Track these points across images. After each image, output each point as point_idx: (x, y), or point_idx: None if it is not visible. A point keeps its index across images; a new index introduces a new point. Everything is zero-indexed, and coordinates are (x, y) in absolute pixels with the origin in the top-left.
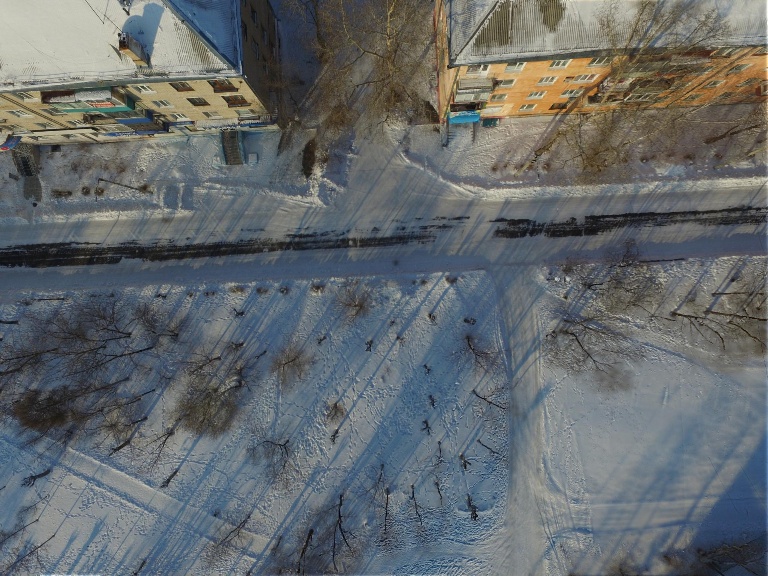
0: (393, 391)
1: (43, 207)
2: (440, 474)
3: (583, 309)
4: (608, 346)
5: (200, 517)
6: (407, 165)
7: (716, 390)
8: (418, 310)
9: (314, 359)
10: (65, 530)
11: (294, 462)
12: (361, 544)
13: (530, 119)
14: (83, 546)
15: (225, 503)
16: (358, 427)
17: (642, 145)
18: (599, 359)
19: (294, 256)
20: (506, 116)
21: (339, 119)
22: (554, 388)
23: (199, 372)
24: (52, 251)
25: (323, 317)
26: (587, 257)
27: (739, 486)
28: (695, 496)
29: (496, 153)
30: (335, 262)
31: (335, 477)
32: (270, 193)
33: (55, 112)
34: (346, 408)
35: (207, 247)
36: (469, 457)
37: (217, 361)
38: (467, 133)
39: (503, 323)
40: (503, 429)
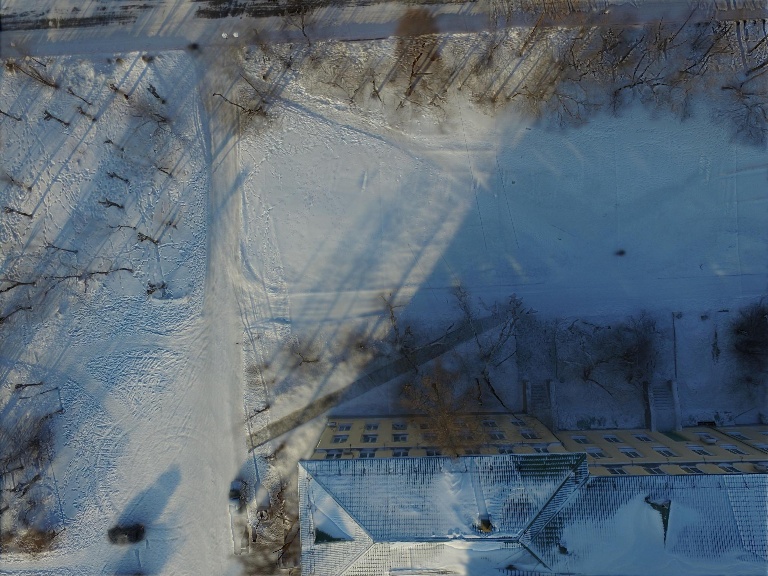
0: (89, 175)
1: None
2: (135, 260)
3: (283, 91)
4: (307, 128)
5: None
6: None
7: (416, 174)
8: (116, 92)
9: (9, 142)
10: None
11: None
12: (54, 333)
13: None
14: None
15: None
16: (52, 212)
17: None
18: (298, 142)
19: None
20: None
21: None
22: (252, 172)
23: None
24: None
25: (19, 98)
26: (289, 38)
27: (439, 274)
28: (395, 285)
29: None
30: (34, 43)
31: (28, 264)
32: None
33: None
34: (41, 192)
35: None
36: (165, 243)
37: None
38: None
39: (202, 106)
40: (200, 215)
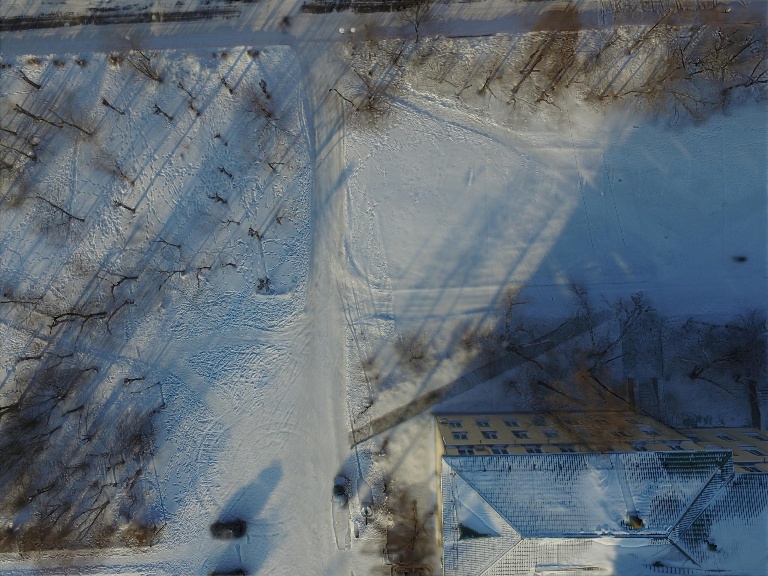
0: (192, 170)
1: None
2: (238, 256)
3: (389, 87)
4: (413, 125)
5: None
6: None
7: (522, 171)
8: (220, 86)
9: (112, 136)
10: None
11: (89, 242)
12: (156, 328)
13: None
14: None
15: (18, 284)
16: (155, 206)
17: None
18: (404, 138)
19: (95, 30)
20: None
21: None
22: (357, 168)
23: None
24: None
25: (122, 92)
26: (394, 34)
27: (545, 272)
28: (500, 282)
29: None
30: (137, 37)
31: (131, 258)
32: None
33: None
34: (144, 187)
35: (7, 21)
36: (269, 239)
37: (12, 136)
38: None
39: (307, 101)
40: (304, 211)
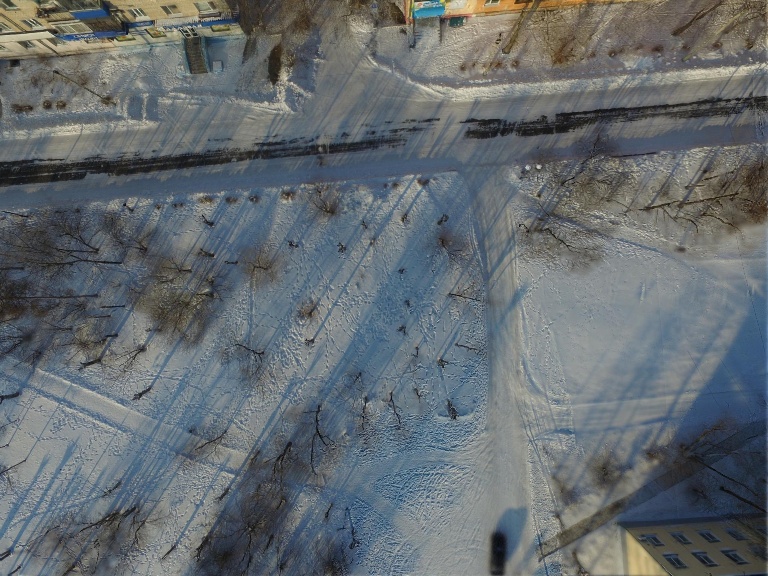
0: (368, 298)
1: (3, 123)
2: (419, 380)
3: (557, 207)
4: (583, 243)
5: (175, 434)
6: (375, 68)
7: (693, 283)
8: (391, 215)
9: (287, 268)
10: (36, 454)
11: (270, 374)
12: (341, 455)
13: (497, 17)
14: (56, 469)
15: (201, 419)
16: (334, 336)
17: (610, 40)
18: (575, 257)
19: (263, 165)
20: (472, 14)
21: (304, 22)
22: (531, 288)
23: (170, 286)
24: (14, 169)
25: (294, 225)
26: (559, 155)
27: (719, 379)
28: (676, 391)
29: (464, 53)
30: (305, 169)
31: (312, 388)
32: (236, 101)
33: (7, 5)
34: (321, 317)
35: (174, 159)
36: (448, 361)
37: (188, 274)
38: (434, 32)
39: (477, 225)
40: (481, 332)
